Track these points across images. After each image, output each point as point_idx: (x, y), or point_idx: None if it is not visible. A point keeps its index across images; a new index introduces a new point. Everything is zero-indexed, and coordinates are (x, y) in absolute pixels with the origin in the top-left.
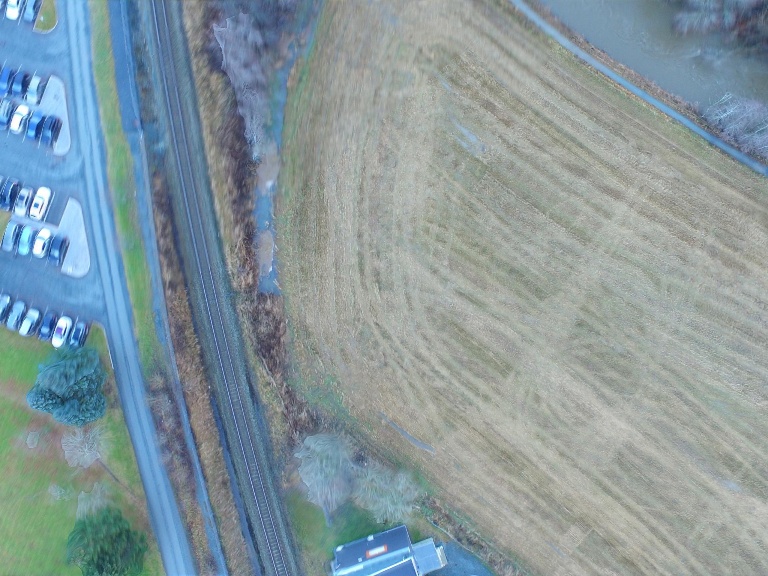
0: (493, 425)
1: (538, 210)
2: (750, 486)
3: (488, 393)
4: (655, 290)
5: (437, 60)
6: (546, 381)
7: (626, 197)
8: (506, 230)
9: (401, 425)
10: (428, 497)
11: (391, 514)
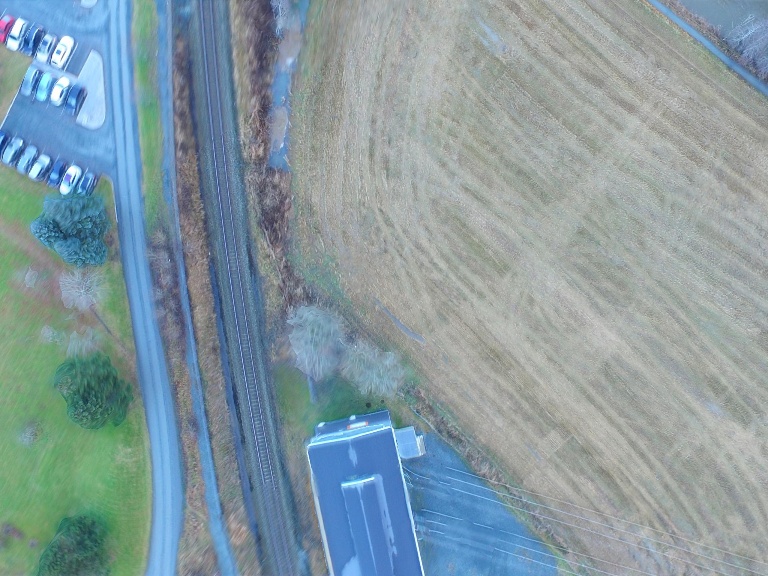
0: (485, 322)
1: (552, 115)
2: (732, 410)
3: (483, 290)
4: (659, 206)
5: None
6: (542, 285)
7: (640, 112)
8: (518, 132)
9: (394, 313)
10: (413, 386)
11: (376, 385)
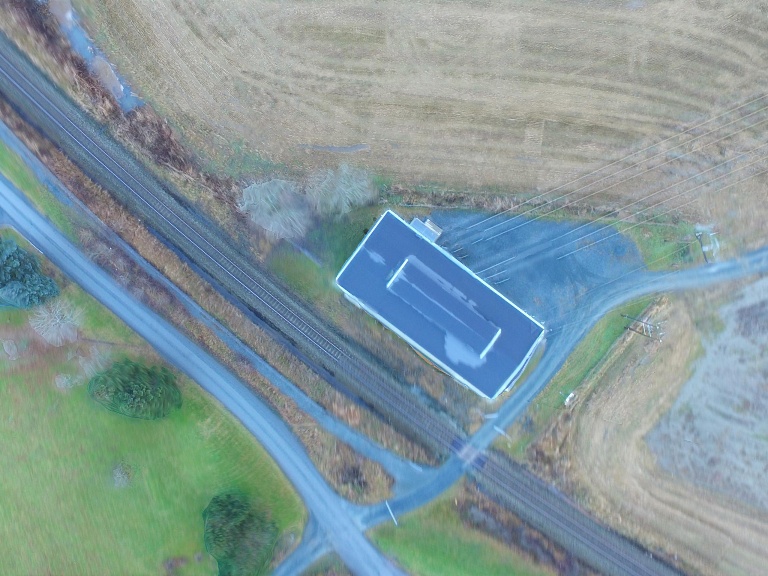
0: (401, 90)
1: None
2: None
3: (378, 67)
4: None
5: None
6: (420, 23)
7: None
8: None
9: (324, 144)
10: (389, 188)
11: (350, 194)
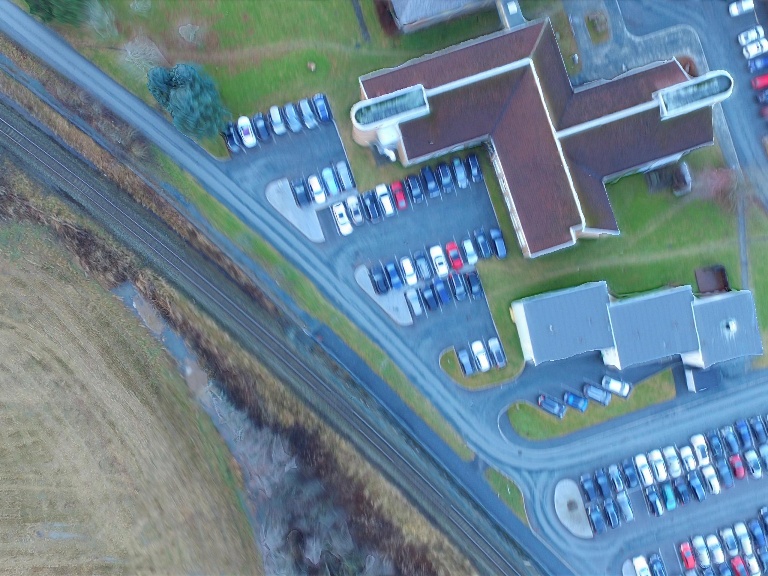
0: None
1: None
2: None
3: None
4: None
5: (134, 573)
6: None
7: None
8: None
9: None
10: None
11: None
